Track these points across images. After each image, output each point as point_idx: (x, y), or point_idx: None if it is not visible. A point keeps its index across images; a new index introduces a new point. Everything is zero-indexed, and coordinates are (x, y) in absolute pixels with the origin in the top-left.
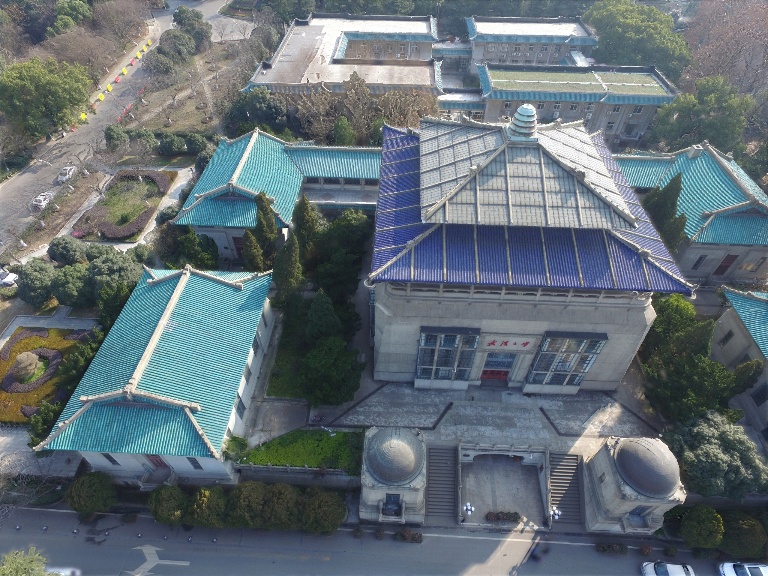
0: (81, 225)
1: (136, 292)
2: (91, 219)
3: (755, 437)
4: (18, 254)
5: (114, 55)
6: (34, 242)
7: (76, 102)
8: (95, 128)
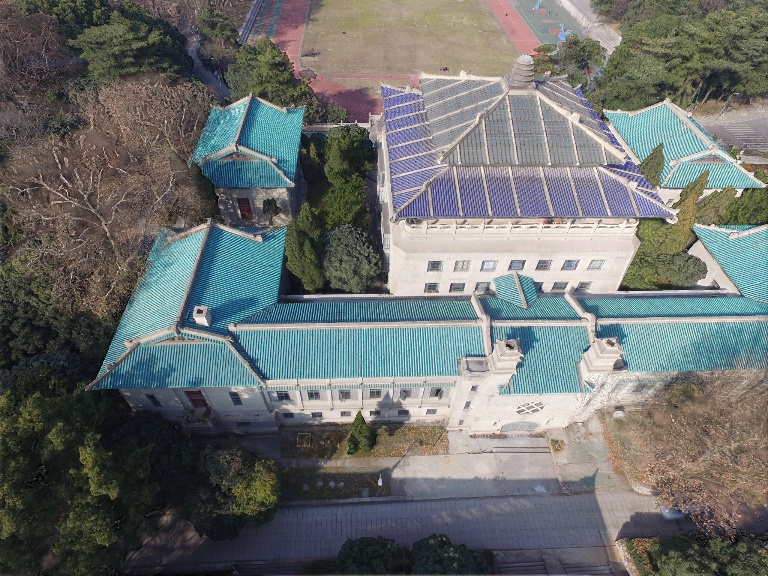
0: None
1: None
2: None
3: (302, 172)
4: None
5: None
6: None
7: None
8: None
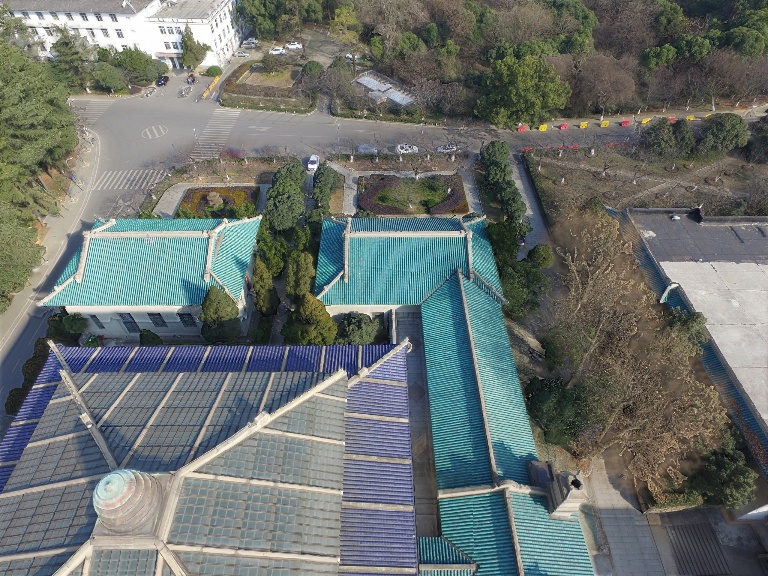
0: (376, 179)
1: (229, 220)
2: (380, 180)
3: None
4: (342, 161)
5: (654, 102)
6: (356, 164)
7: (524, 110)
8: (530, 141)
